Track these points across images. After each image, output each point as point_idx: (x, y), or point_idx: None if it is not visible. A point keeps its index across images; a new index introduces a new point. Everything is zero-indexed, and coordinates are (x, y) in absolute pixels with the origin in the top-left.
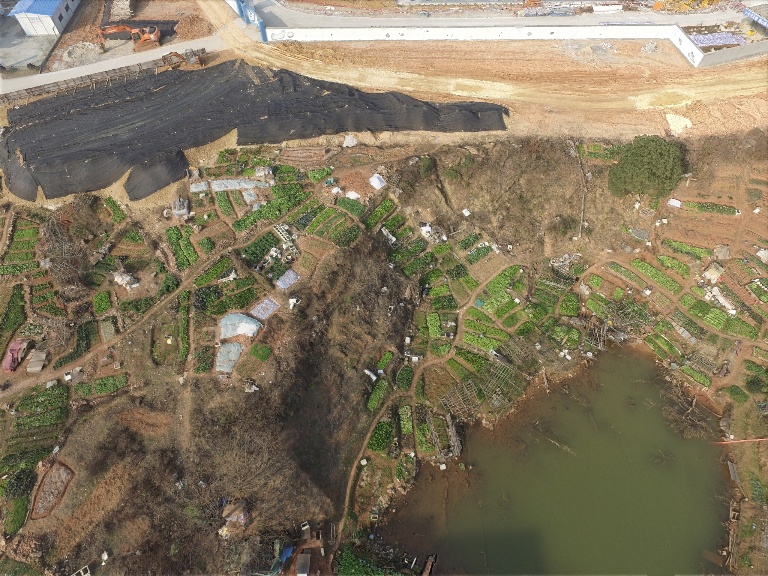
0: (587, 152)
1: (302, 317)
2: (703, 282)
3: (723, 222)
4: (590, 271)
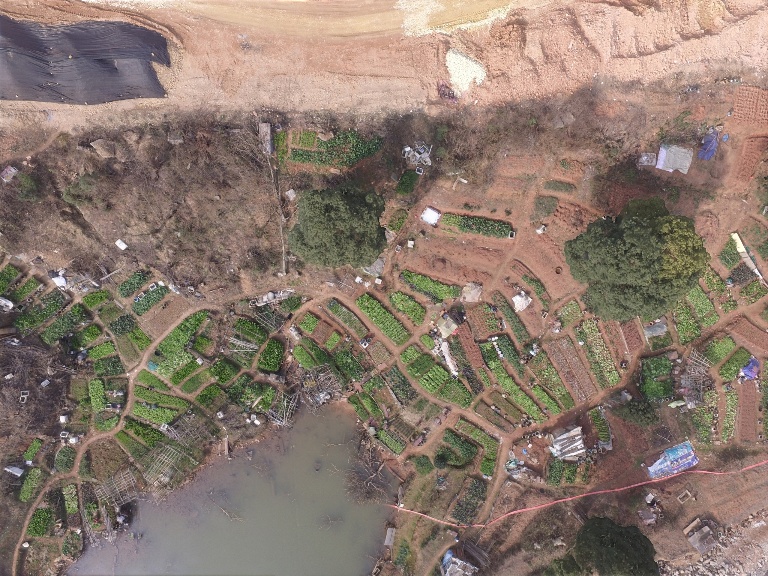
0: (290, 150)
1: None
2: (436, 332)
3: (489, 247)
4: (306, 307)
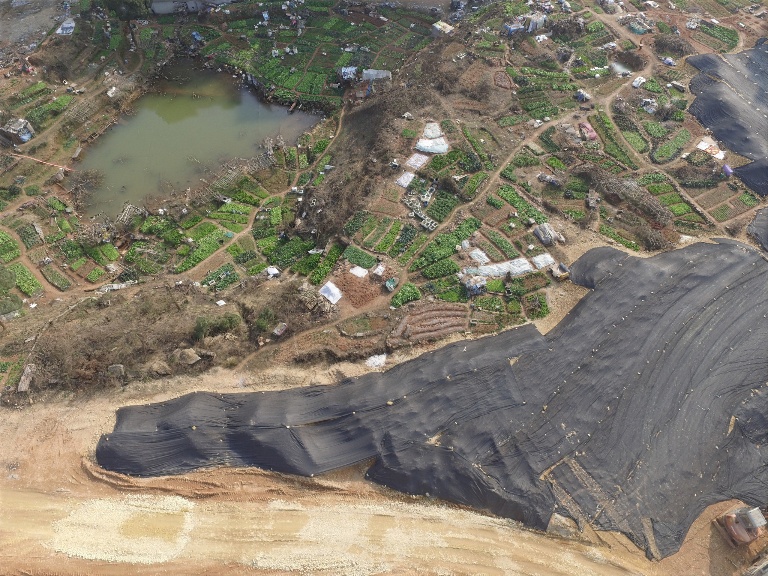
0: (8, 370)
1: (385, 158)
2: None
3: None
4: (95, 286)
